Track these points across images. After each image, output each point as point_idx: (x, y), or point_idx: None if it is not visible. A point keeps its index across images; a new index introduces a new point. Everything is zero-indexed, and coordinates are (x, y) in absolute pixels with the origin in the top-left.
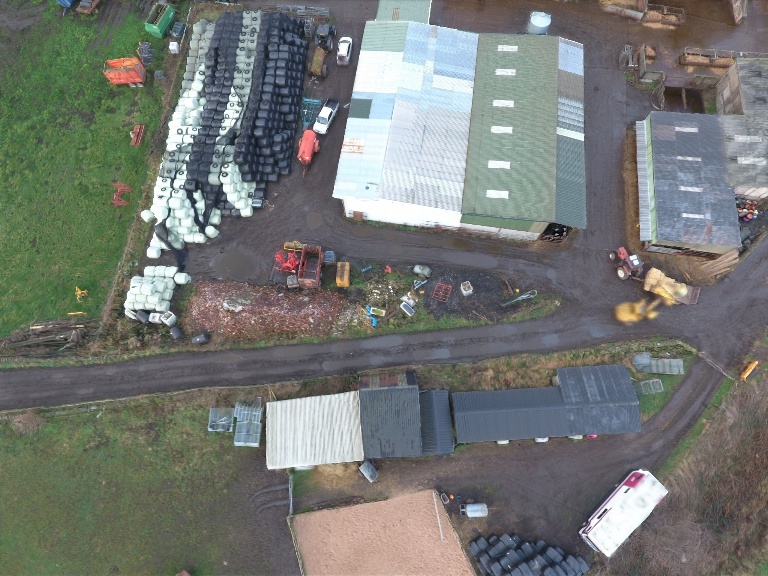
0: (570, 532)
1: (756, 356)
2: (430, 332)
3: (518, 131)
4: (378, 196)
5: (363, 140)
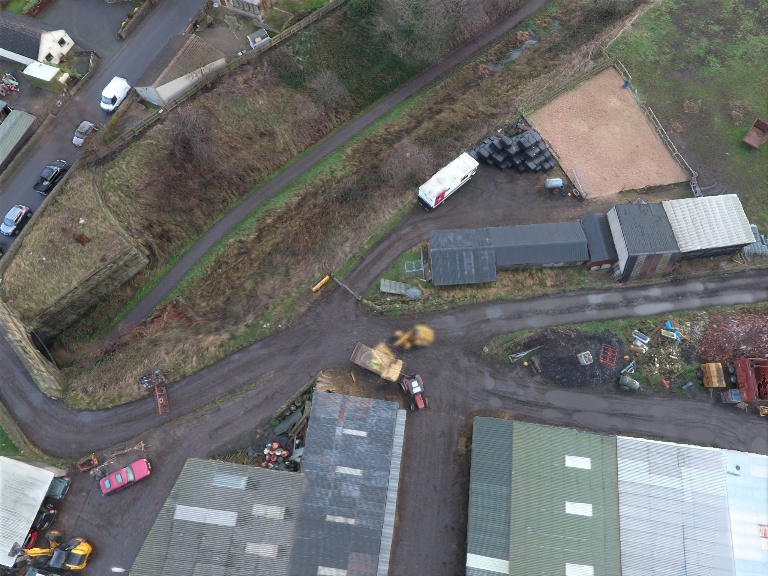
0: (479, 175)
1: (308, 298)
2: (610, 318)
3: (559, 567)
4: (723, 454)
5: (764, 548)
